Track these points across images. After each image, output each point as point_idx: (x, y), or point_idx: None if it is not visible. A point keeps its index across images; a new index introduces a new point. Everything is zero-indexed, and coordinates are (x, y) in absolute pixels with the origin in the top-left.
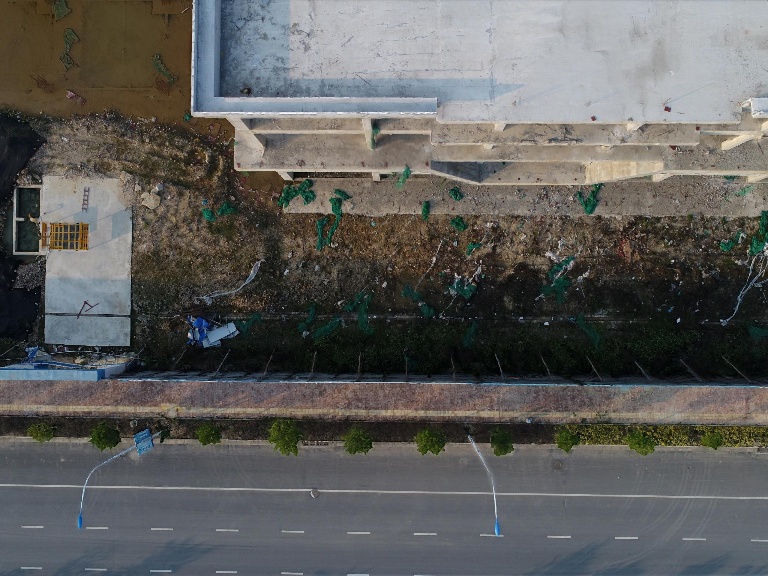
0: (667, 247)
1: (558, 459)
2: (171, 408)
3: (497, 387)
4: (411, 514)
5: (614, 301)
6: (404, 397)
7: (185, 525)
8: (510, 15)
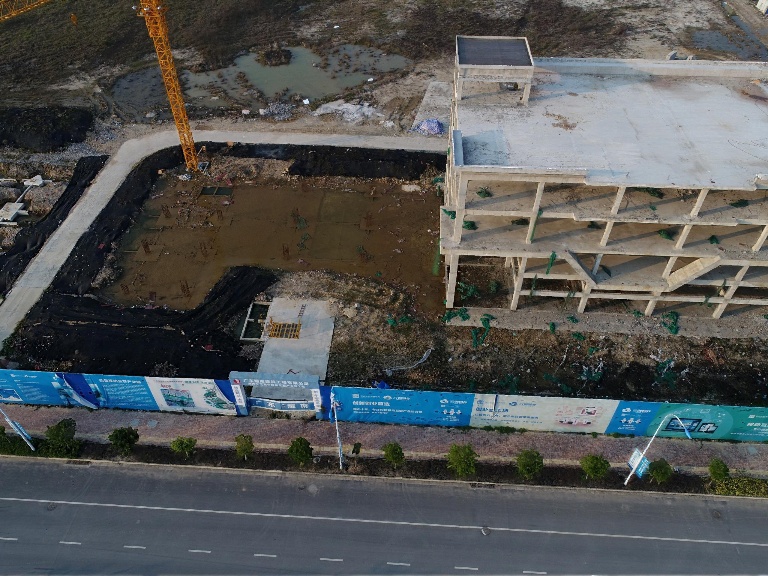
0: (742, 357)
1: (715, 509)
2: (352, 449)
3: (639, 444)
4: (585, 555)
5: (716, 386)
6: (559, 449)
7: (356, 556)
8: (613, 152)
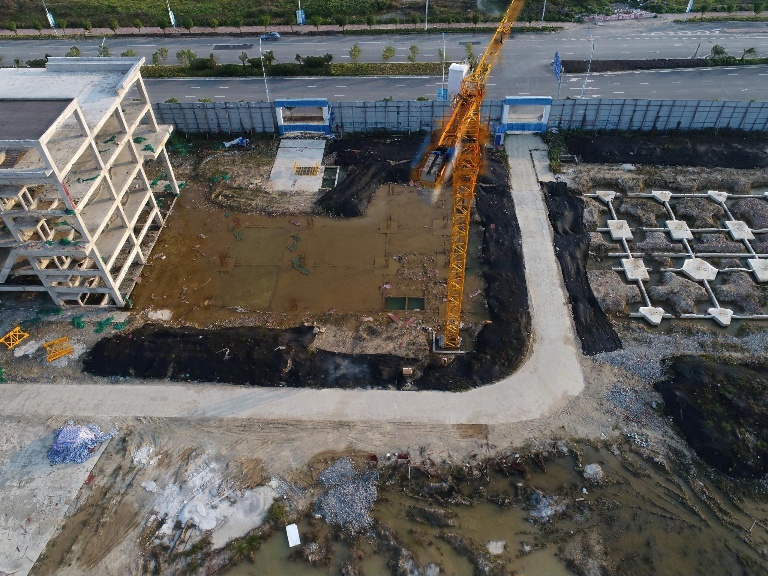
0: None
1: None
2: None
3: None
4: None
5: None
6: None
7: None
8: None
